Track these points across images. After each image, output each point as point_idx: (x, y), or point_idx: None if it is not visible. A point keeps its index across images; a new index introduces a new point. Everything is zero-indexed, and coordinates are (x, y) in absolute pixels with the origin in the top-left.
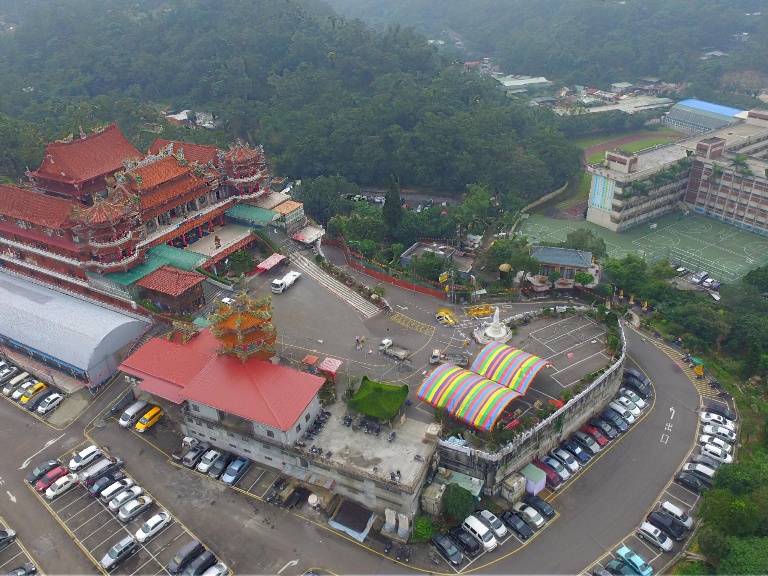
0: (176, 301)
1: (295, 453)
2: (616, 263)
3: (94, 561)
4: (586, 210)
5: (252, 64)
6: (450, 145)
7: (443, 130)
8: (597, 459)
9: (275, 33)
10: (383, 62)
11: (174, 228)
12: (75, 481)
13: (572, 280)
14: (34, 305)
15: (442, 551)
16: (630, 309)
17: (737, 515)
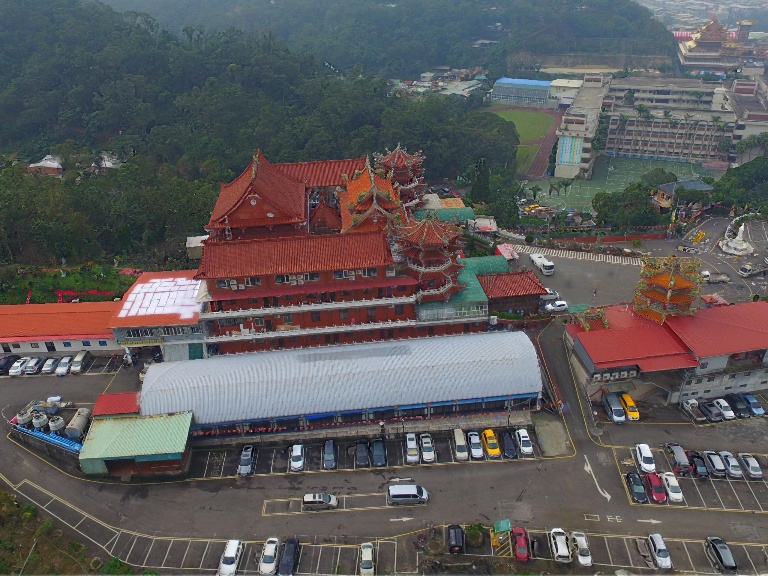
0: (535, 300)
1: None
2: None
3: None
4: (551, 169)
5: (144, 86)
6: (419, 136)
7: (405, 124)
8: None
9: (140, 50)
10: (287, 69)
11: None
12: None
13: None
14: (402, 358)
15: None
16: None
17: None
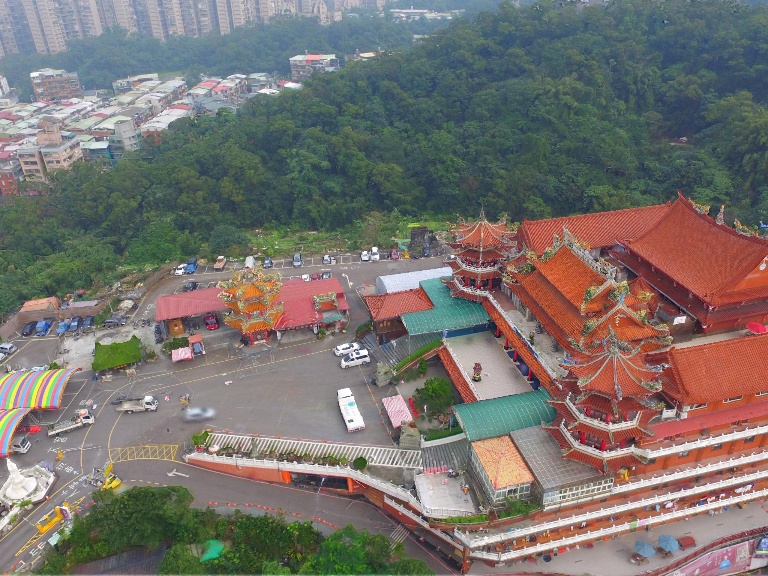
0: None
1: None
2: None
3: None
4: None
5: None
6: None
7: None
8: None
9: None
10: None
11: None
12: None
13: None
14: None
15: None
16: None
17: None
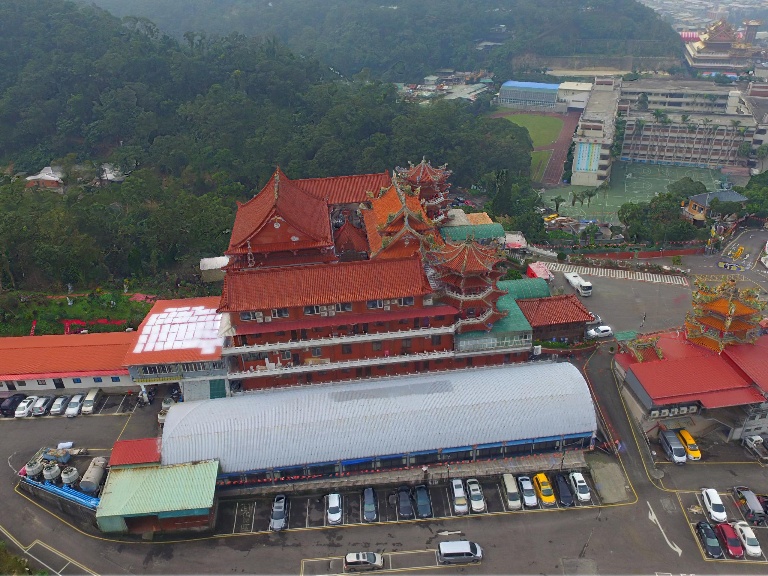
0: (580, 328)
1: None
2: None
3: None
4: (567, 176)
5: (145, 95)
6: (432, 144)
7: (417, 131)
8: None
9: (140, 56)
10: (292, 75)
11: None
12: None
13: None
14: (444, 396)
15: None
16: None
17: None
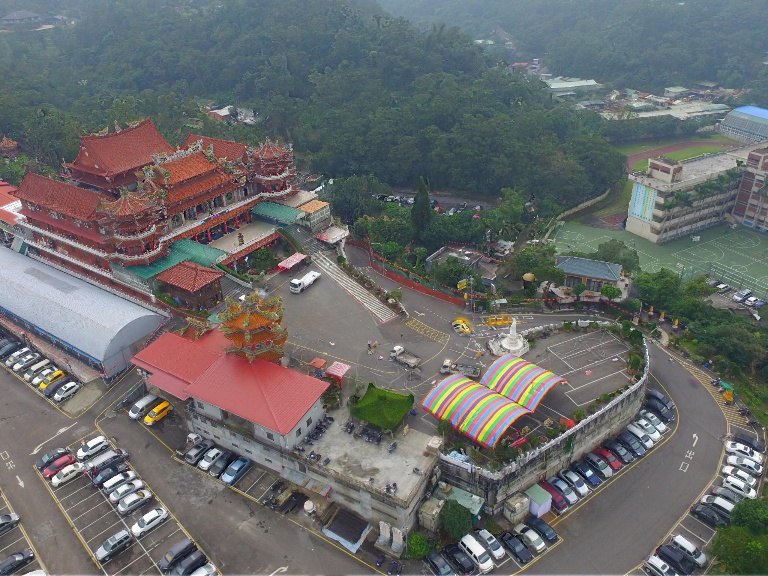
0: (193, 296)
1: (293, 457)
2: (647, 277)
3: (90, 552)
4: (626, 219)
5: (295, 61)
6: (487, 148)
7: (481, 132)
8: (609, 484)
9: (319, 31)
10: (425, 62)
11: (199, 223)
12: (81, 470)
13: (599, 293)
14: (59, 294)
15: (435, 569)
16: (657, 327)
17: (752, 557)
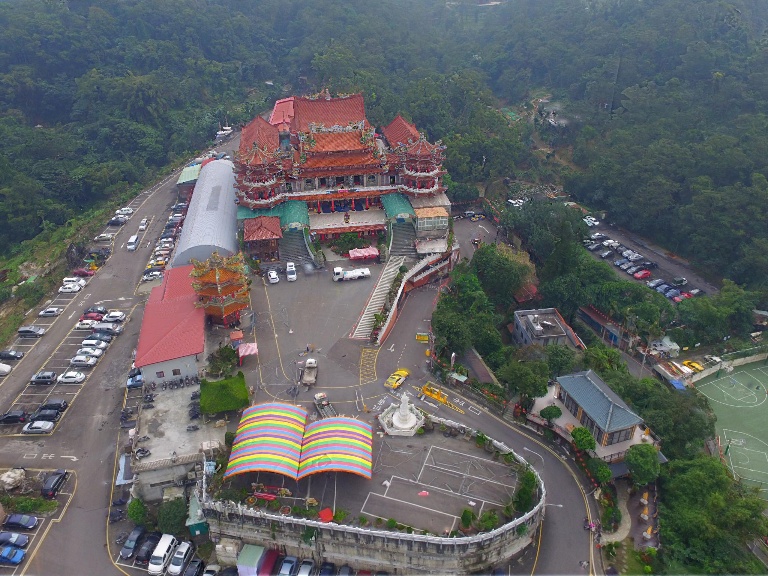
0: None
1: None
2: (648, 449)
3: None
4: None
5: (626, 69)
6: (761, 224)
7: (767, 202)
8: None
9: (681, 40)
10: None
11: (325, 192)
12: None
13: None
14: (203, 209)
15: None
16: None
17: None
